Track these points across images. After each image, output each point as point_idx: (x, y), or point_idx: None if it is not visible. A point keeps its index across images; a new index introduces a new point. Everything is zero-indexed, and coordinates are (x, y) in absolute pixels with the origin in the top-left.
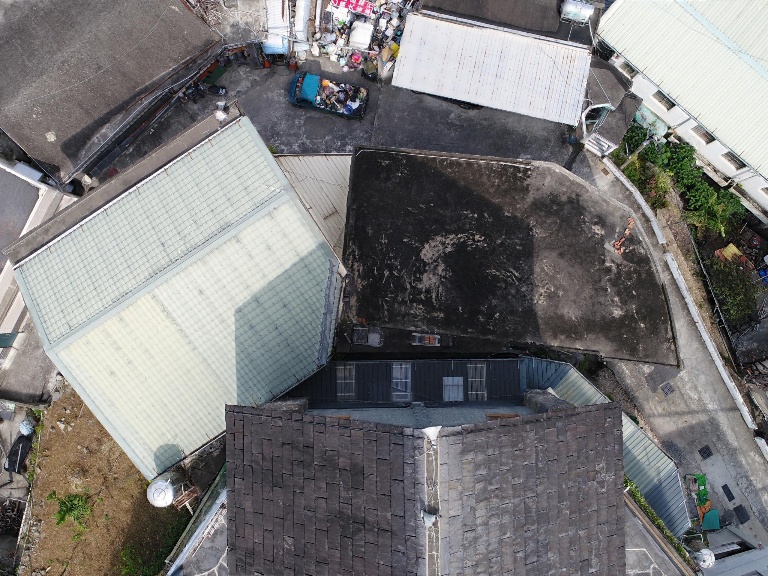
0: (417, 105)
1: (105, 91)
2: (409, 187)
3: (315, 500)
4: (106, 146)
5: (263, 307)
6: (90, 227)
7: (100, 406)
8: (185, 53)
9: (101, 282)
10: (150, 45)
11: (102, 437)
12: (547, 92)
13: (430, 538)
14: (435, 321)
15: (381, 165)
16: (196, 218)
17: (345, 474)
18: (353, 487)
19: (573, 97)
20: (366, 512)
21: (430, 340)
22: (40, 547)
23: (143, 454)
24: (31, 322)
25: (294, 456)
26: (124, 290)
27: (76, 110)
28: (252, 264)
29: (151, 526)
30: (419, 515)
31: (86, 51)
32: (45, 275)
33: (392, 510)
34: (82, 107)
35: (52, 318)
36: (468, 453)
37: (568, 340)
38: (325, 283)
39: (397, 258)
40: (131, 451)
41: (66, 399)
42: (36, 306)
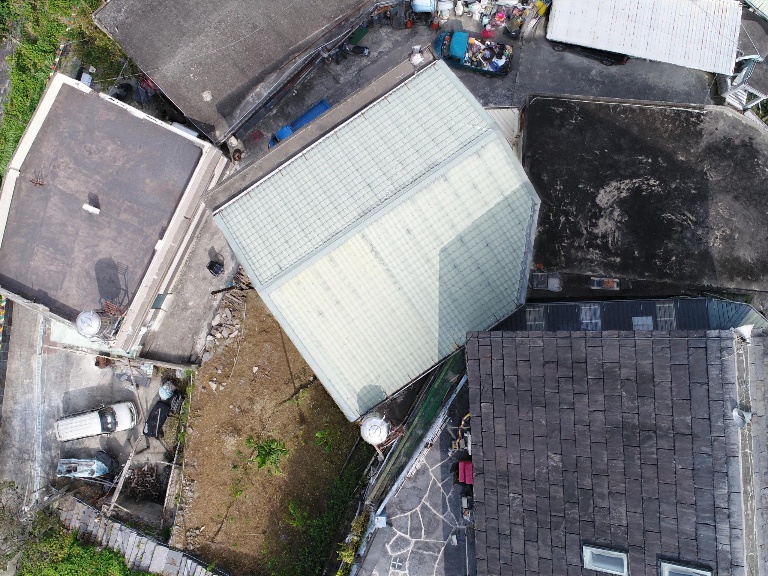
0: (558, 62)
1: (260, 50)
2: (583, 134)
3: (590, 414)
4: (260, 105)
5: (467, 246)
6: (290, 171)
7: (308, 347)
8: (337, 11)
9: (308, 224)
10: (304, 4)
11: (254, 396)
12: (701, 43)
13: (743, 436)
14: (612, 266)
15: (555, 112)
16: (401, 159)
17: (629, 384)
18: (640, 396)
19: (727, 47)
20: (658, 419)
21: (609, 284)
22: (194, 507)
23: (347, 395)
24: (179, 284)
25: (560, 373)
26: (334, 230)
27: (232, 69)
28: (458, 203)
29: (310, 482)
30: (730, 414)
31: (242, 10)
32: (248, 219)
33: (693, 413)
34: (237, 66)
35: (261, 260)
36: (766, 356)
37: (744, 282)
38: (527, 222)
39: (573, 204)
40: (336, 392)
41: (217, 359)
42: (242, 249)
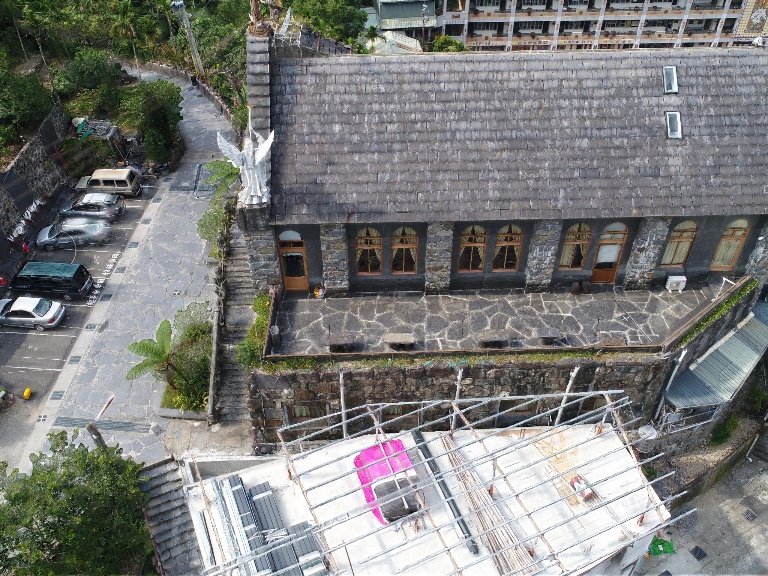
0: None
1: None
2: None
3: None
4: None
5: None
6: None
7: None
8: None
9: None
10: None
11: None
12: None
13: None
14: None
15: None
16: None
17: None
18: None
19: None
20: None
21: None
22: None
23: None
24: None
25: None
26: None
27: None
28: None
29: None
30: None
31: None
32: None
33: None
34: None
35: None
36: None
37: None
38: None
39: None
40: None
41: None
42: None
